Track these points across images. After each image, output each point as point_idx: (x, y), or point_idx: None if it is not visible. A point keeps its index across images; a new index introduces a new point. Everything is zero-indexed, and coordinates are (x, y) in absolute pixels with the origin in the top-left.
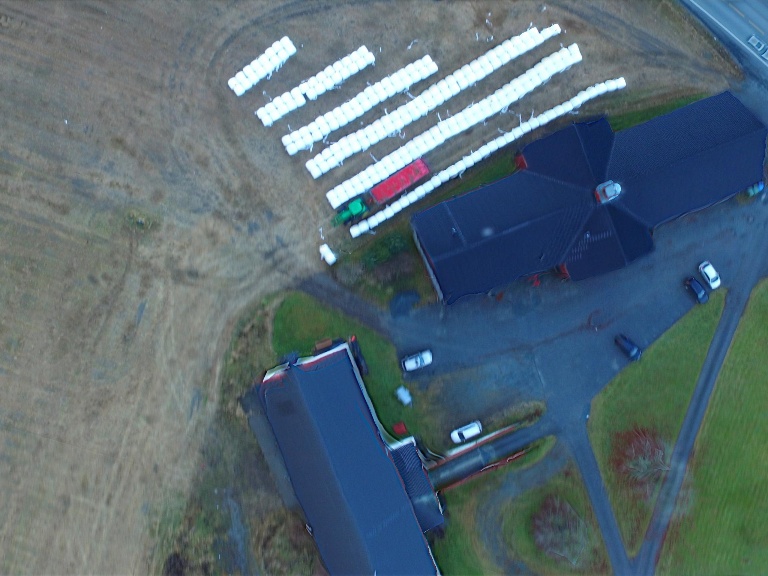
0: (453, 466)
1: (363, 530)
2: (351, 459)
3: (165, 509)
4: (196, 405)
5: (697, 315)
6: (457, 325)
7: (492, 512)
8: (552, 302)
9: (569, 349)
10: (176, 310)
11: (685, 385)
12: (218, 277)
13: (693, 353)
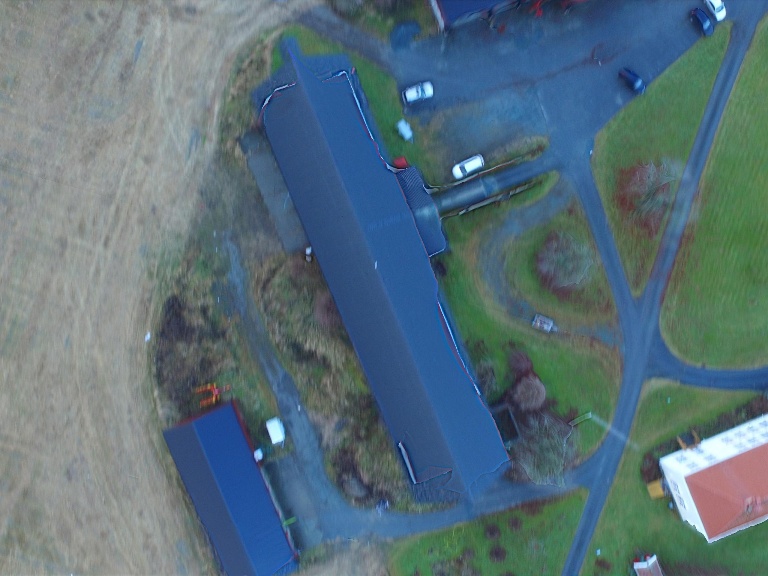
0: (455, 195)
1: (363, 224)
2: (351, 156)
3: (163, 251)
4: (194, 145)
5: (702, 48)
6: (458, 58)
7: (494, 250)
8: (555, 35)
9: (572, 83)
10: (174, 48)
11: (690, 120)
12: (216, 13)
13: (698, 87)
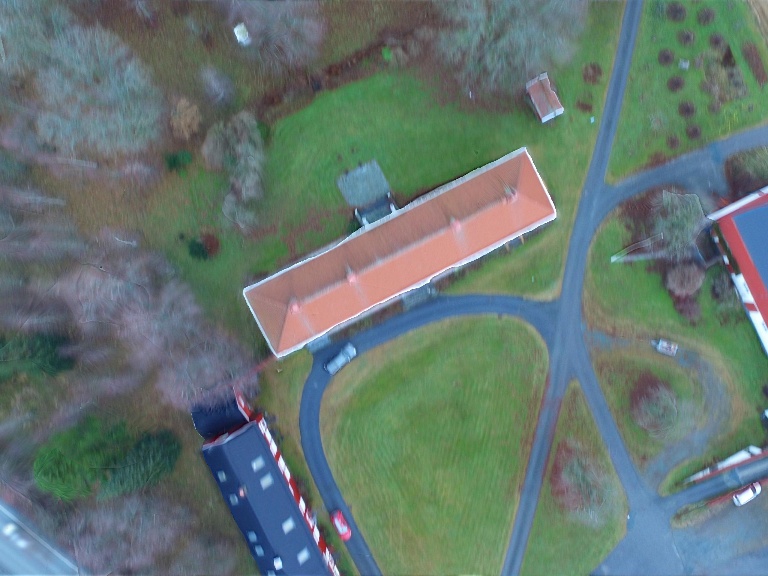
0: None
1: None
2: None
3: None
4: None
5: None
6: None
7: (716, 414)
8: None
9: None
10: None
11: (535, 557)
12: None
13: None
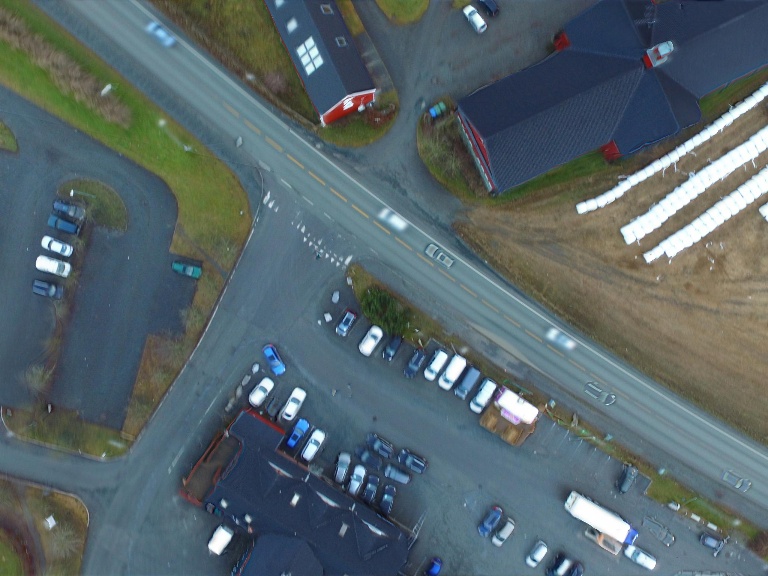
0: None
1: None
2: None
3: None
4: None
5: None
6: None
7: None
8: None
9: None
10: None
11: None
12: None
13: None
